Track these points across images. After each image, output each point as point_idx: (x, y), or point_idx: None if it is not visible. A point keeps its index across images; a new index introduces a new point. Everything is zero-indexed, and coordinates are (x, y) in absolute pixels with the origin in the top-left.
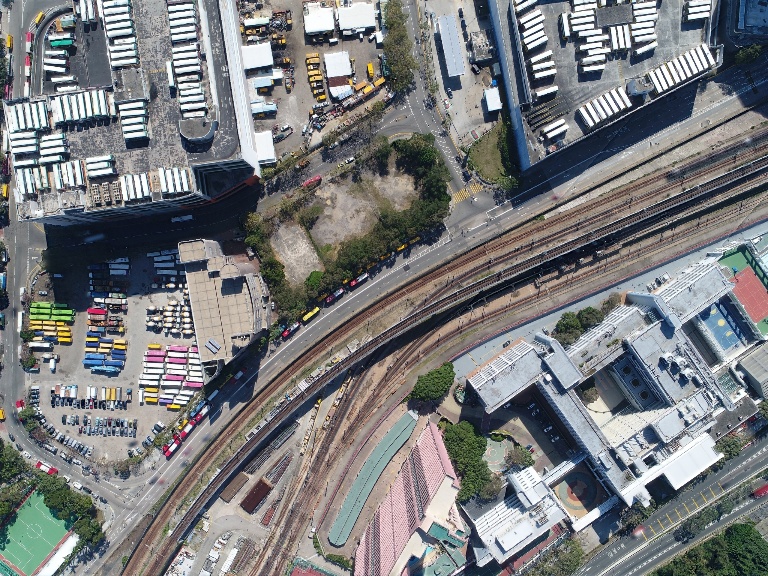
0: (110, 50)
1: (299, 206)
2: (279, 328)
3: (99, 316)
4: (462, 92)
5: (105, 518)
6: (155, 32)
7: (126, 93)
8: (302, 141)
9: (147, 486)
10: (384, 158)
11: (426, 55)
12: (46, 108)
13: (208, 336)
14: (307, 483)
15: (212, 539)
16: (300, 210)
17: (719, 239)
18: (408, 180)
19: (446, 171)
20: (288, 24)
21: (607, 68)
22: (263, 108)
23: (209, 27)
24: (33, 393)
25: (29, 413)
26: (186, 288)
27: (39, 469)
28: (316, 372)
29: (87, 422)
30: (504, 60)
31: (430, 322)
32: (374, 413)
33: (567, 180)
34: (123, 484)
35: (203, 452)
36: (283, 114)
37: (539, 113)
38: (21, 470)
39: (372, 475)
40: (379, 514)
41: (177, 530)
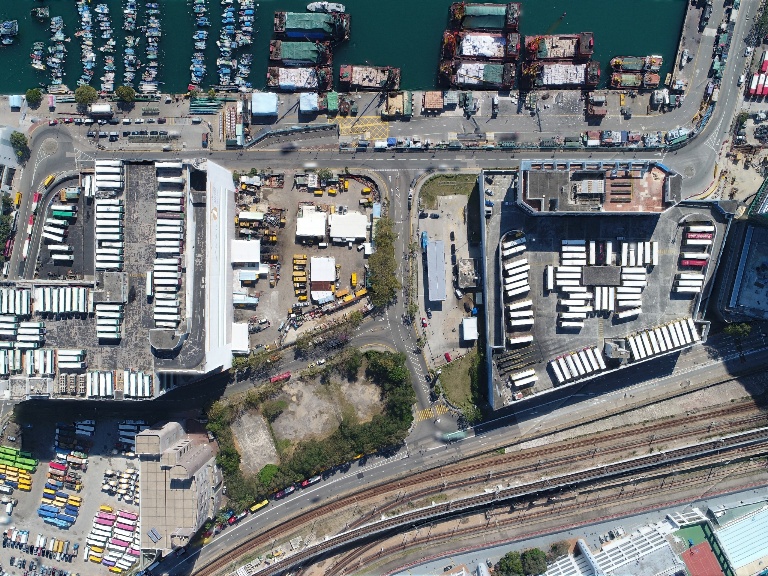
0: (96, 252)
1: (265, 398)
2: (226, 515)
3: (59, 471)
4: (442, 314)
5: None
6: (142, 238)
7: (105, 295)
8: (277, 336)
9: None
10: (353, 370)
11: (412, 272)
12: (29, 295)
13: (151, 524)
14: None
15: None
16: (265, 402)
17: (682, 503)
18: (375, 390)
19: (411, 394)
20: (281, 222)
21: (587, 324)
22: (244, 300)
23: (196, 237)
24: None
25: None
26: None
27: None
28: (256, 561)
29: (33, 568)
30: (486, 295)
31: (375, 533)
32: None
33: (534, 417)
34: None
35: None
36: (263, 307)
37: (511, 358)
38: None
39: None
40: None
41: None
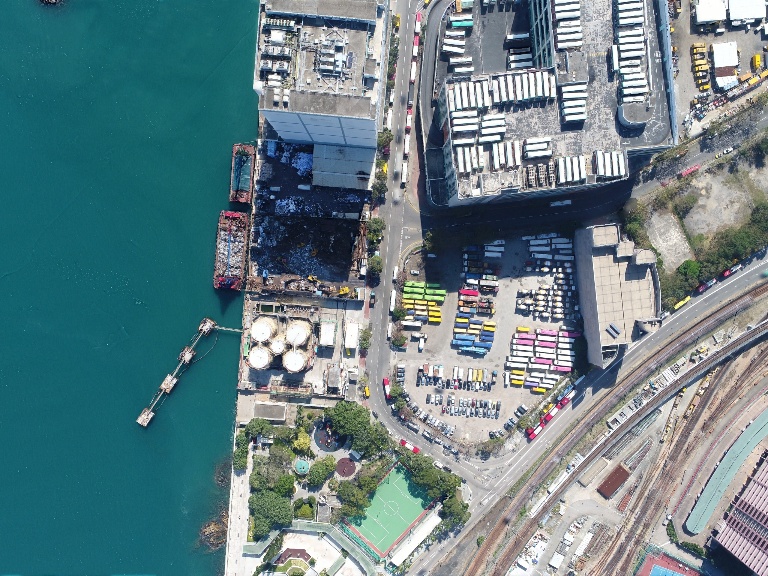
0: (557, 32)
1: (674, 195)
2: None
3: (472, 297)
4: None
5: (463, 498)
6: (597, 15)
7: (570, 75)
8: (681, 130)
9: (506, 468)
10: None
11: None
12: None
13: (609, 320)
14: (664, 471)
15: (567, 523)
16: (675, 199)
17: None
18: None
19: None
20: (677, 13)
21: None
22: None
23: None
24: (400, 371)
25: (400, 391)
26: (559, 272)
27: (405, 447)
28: (682, 361)
29: (451, 402)
30: None
31: None
32: (735, 404)
33: None
34: (483, 465)
35: (564, 436)
36: None
37: None
38: (388, 447)
39: (733, 465)
40: (749, 504)
41: (539, 512)
